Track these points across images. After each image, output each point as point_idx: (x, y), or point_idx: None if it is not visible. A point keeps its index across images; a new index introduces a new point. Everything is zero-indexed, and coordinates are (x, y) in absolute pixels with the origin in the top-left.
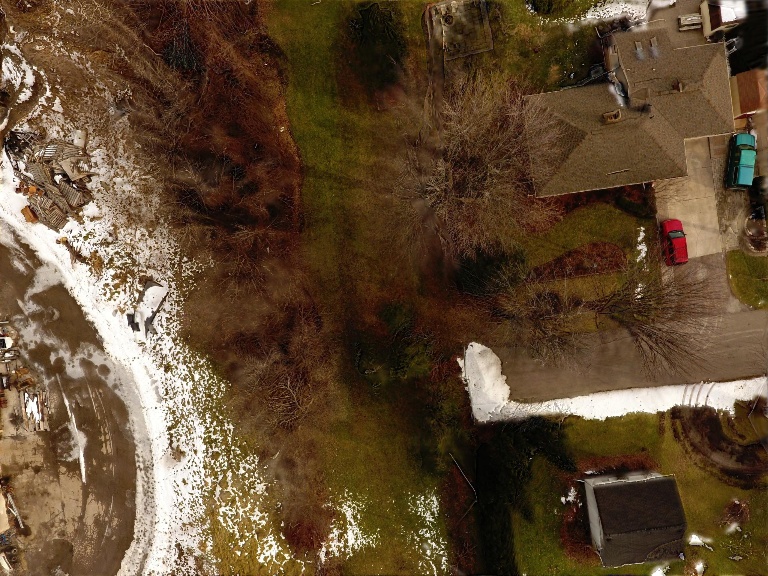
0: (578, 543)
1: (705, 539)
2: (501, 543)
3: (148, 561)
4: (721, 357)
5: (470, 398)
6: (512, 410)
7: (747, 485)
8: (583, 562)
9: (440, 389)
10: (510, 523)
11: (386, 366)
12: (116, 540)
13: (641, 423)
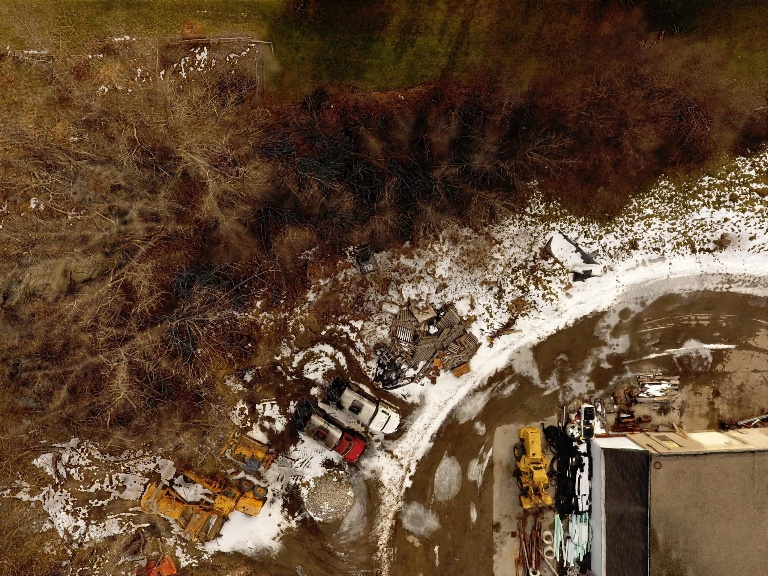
0: None
1: None
2: None
3: None
4: None
5: None
6: None
7: None
8: None
9: None
10: None
11: None
12: None
13: None
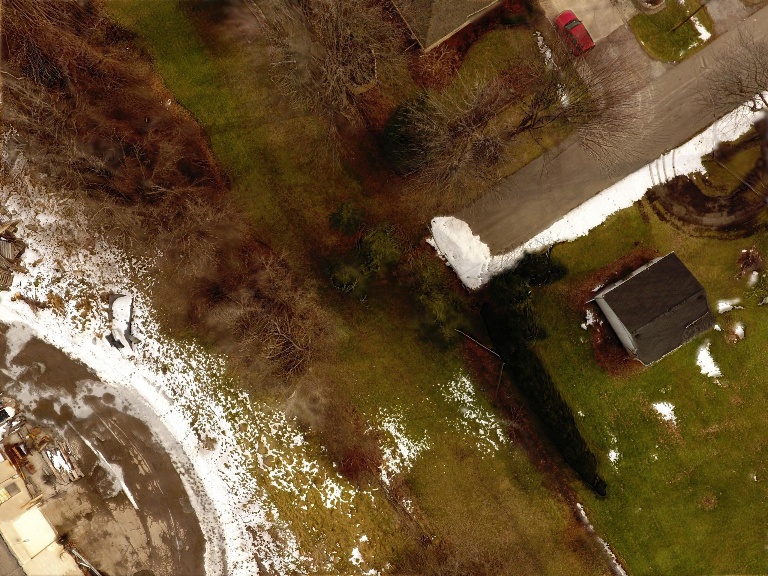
0: (615, 360)
1: (731, 301)
2: (539, 385)
3: (228, 555)
4: (668, 123)
5: (454, 271)
6: (498, 264)
7: (748, 233)
8: (628, 376)
9: (423, 275)
10: (540, 365)
11: (363, 276)
12: (190, 549)
13: (623, 221)
